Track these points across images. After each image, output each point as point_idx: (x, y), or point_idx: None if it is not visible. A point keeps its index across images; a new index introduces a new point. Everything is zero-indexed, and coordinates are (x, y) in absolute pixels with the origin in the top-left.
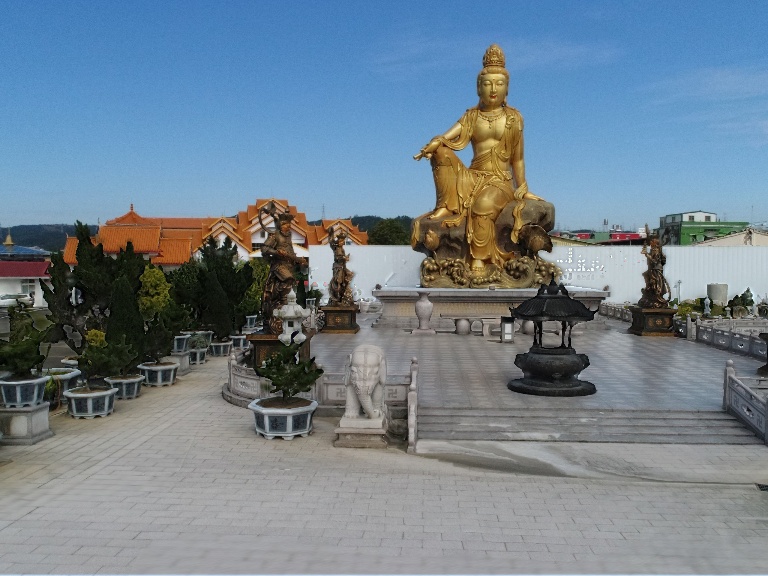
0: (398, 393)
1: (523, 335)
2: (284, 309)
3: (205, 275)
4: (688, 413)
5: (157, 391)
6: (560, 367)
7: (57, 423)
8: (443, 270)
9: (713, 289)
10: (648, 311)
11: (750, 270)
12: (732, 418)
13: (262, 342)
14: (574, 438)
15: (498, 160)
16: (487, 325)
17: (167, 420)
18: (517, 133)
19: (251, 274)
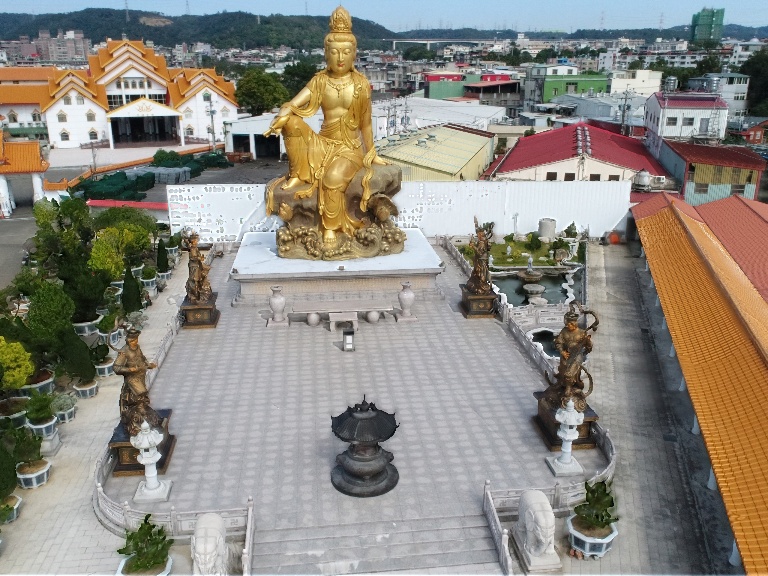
0: (239, 522)
1: (366, 324)
2: (139, 440)
3: (63, 331)
4: (457, 518)
5: (34, 500)
6: (369, 472)
7: None
8: (298, 238)
9: (543, 226)
10: (473, 298)
11: (577, 203)
12: (485, 525)
13: (124, 447)
14: (368, 569)
15: (347, 129)
16: (333, 322)
17: (49, 570)
18: (365, 101)
19: (108, 277)
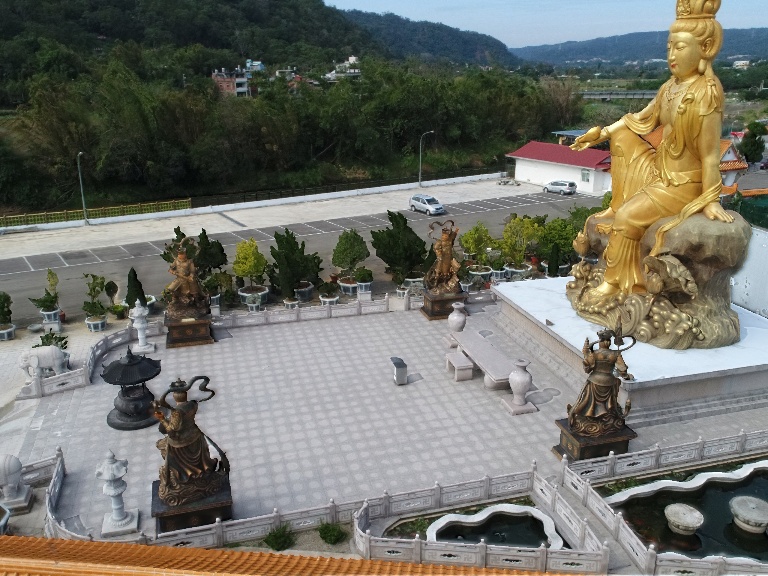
0: None
1: (481, 384)
2: None
3: None
4: None
5: None
6: None
7: (83, 328)
8: None
9: None
10: None
11: None
12: None
13: None
14: None
15: (667, 156)
16: None
17: None
18: (696, 119)
19: (410, 245)
